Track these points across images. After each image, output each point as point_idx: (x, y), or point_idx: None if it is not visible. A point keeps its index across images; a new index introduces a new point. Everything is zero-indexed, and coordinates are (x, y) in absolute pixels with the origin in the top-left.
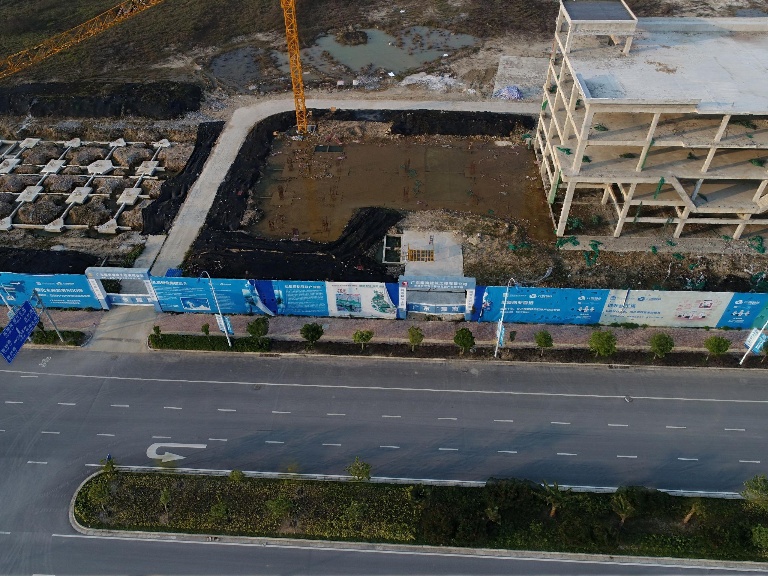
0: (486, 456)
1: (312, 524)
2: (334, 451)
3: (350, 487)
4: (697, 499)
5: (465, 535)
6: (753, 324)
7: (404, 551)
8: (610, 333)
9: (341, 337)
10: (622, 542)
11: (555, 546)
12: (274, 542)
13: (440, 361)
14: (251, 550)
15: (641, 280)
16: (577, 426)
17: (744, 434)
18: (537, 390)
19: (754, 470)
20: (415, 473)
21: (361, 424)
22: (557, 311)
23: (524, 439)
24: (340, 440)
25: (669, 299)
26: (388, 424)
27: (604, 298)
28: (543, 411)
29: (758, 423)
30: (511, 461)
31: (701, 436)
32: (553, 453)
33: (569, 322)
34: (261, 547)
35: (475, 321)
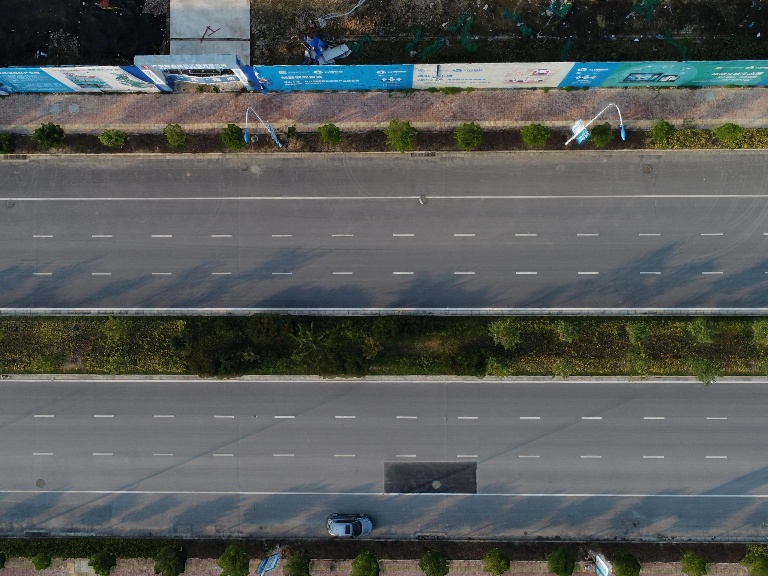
0: (259, 280)
1: (91, 361)
2: (105, 281)
3: (123, 322)
4: (458, 318)
5: (226, 373)
6: (603, 83)
7: (178, 380)
8: (407, 127)
9: (96, 125)
10: (375, 364)
11: (314, 370)
12: (60, 377)
13: (216, 156)
14: (41, 385)
15: (489, 1)
16: (359, 239)
17: (533, 240)
18: (323, 193)
19: (527, 283)
20: (187, 302)
21: (130, 247)
22: (356, 81)
23: (301, 258)
24: (109, 268)
25: (493, 69)
26: (158, 246)
27: (410, 71)
28: (326, 221)
29: (554, 226)
30: (284, 284)
31: (487, 245)
32: (328, 273)
33: (376, 88)
34: (49, 382)
35: (260, 91)
